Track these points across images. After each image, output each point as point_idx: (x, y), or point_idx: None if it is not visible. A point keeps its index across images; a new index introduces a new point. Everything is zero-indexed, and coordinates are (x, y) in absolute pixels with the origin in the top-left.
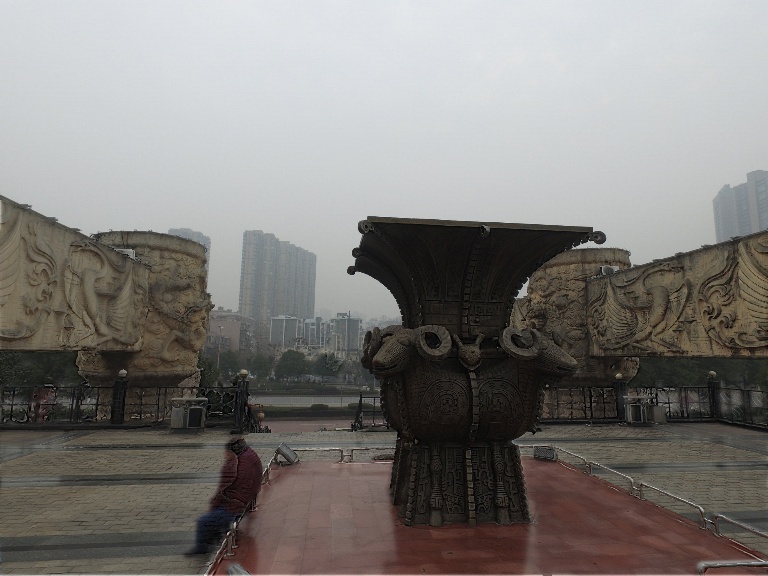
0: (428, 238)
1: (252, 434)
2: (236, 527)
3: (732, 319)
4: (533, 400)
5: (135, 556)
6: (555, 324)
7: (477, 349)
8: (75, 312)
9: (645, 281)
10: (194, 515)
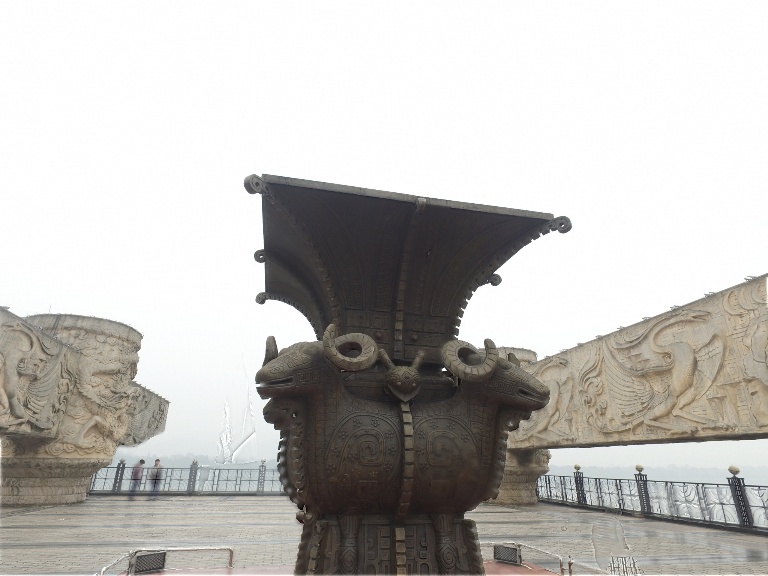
0: None
1: None
2: (569, 564)
3: None
4: None
5: None
6: None
7: None
8: None
9: None
10: None
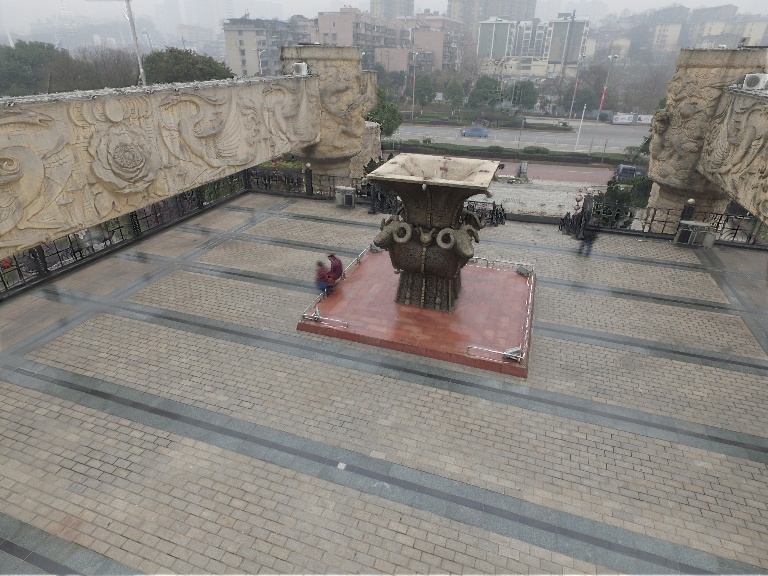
0: (401, 183)
1: (380, 215)
2: None
3: (767, 185)
4: (455, 264)
5: (298, 291)
6: (674, 132)
7: (428, 237)
8: (274, 134)
9: (750, 115)
10: (324, 275)
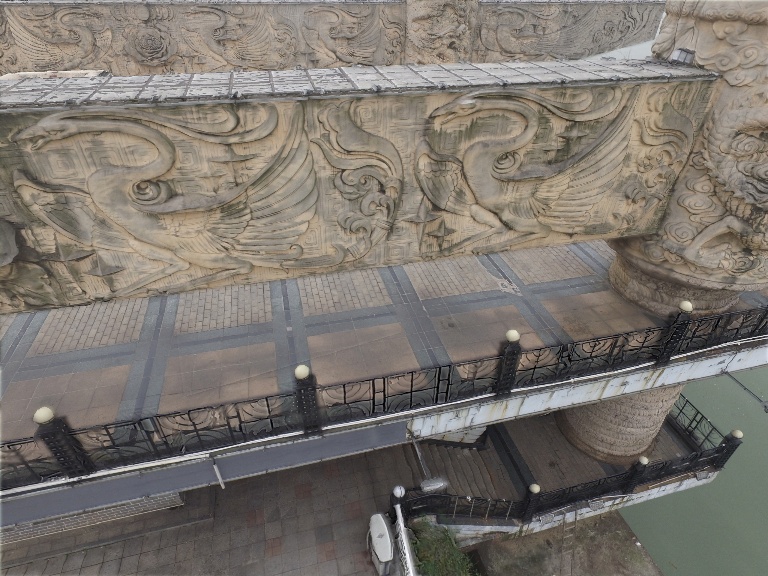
0: None
1: None
2: None
3: (15, 59)
4: None
5: None
6: None
7: None
8: None
9: None
10: None
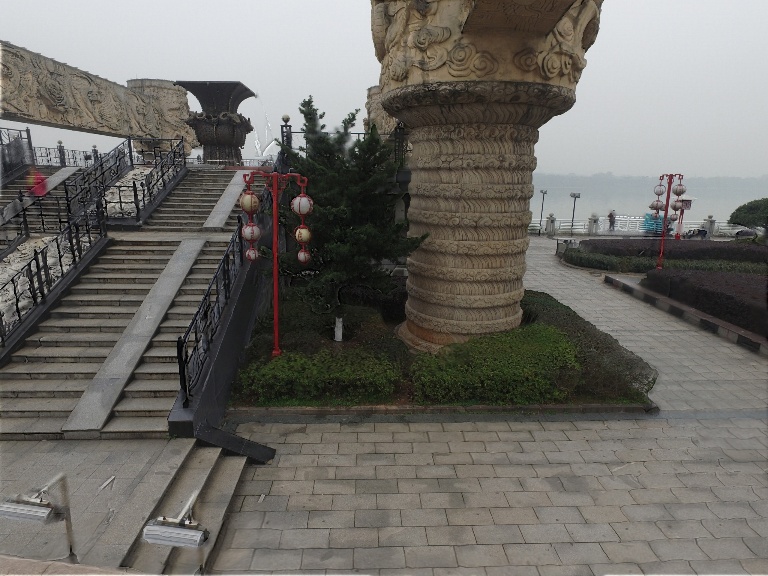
0: None
1: None
2: None
3: None
4: None
5: None
6: None
7: None
8: None
9: None
10: None
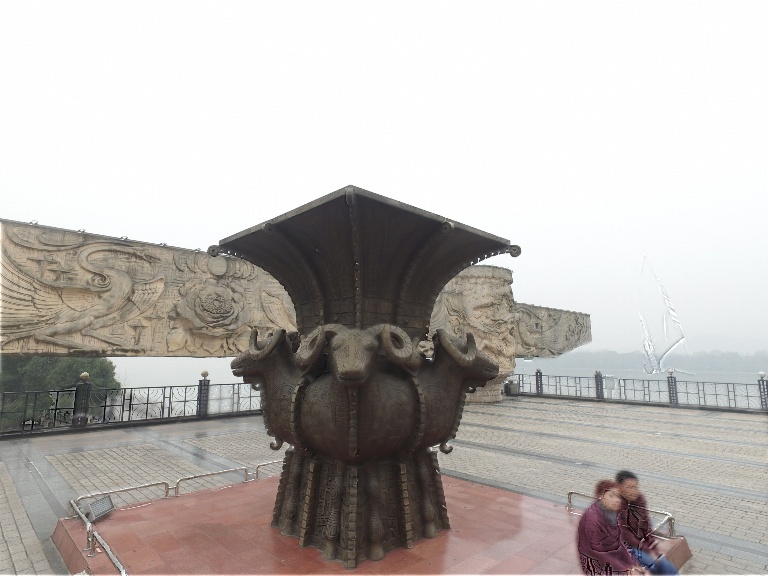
0: None
1: None
2: (631, 553)
3: None
4: None
5: None
6: None
7: None
8: None
9: None
10: None
